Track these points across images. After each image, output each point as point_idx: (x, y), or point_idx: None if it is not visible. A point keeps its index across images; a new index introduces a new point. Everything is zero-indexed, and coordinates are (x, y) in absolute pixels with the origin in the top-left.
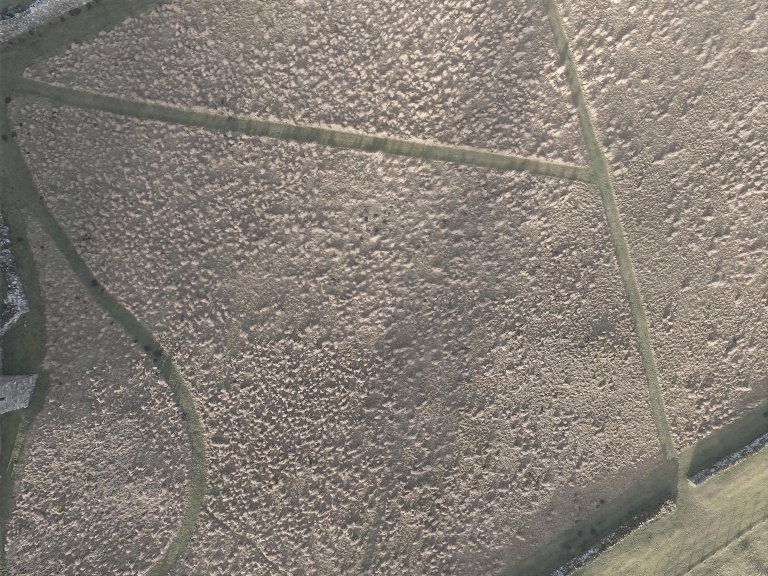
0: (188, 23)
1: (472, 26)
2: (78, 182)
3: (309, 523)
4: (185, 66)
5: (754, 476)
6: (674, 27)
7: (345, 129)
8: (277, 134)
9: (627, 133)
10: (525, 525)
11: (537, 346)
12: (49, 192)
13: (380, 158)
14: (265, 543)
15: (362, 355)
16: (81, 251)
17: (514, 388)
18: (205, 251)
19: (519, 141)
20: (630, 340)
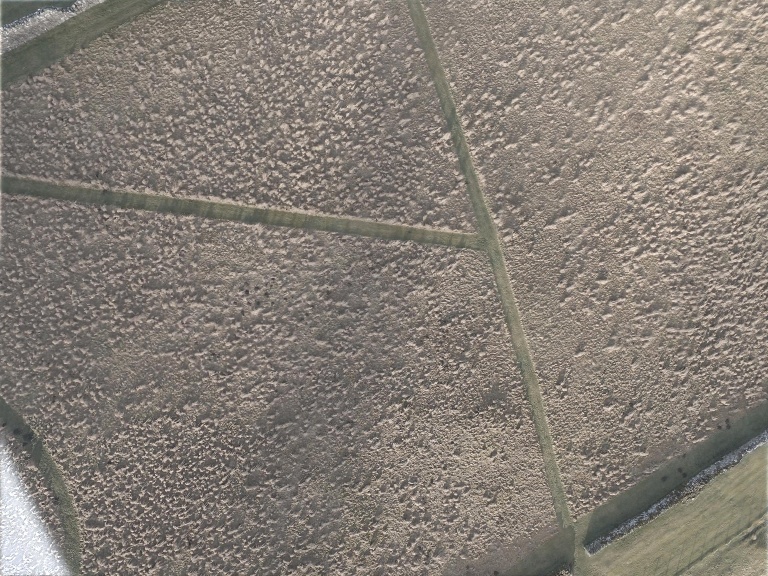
0: (61, 95)
1: (355, 93)
2: None
3: None
4: (58, 139)
5: (653, 542)
6: (565, 89)
7: (224, 201)
8: (154, 207)
9: (517, 198)
10: None
11: (425, 418)
12: None
13: (260, 230)
14: None
15: (244, 431)
16: None
17: (402, 461)
18: (78, 329)
19: (404, 210)
20: (522, 408)
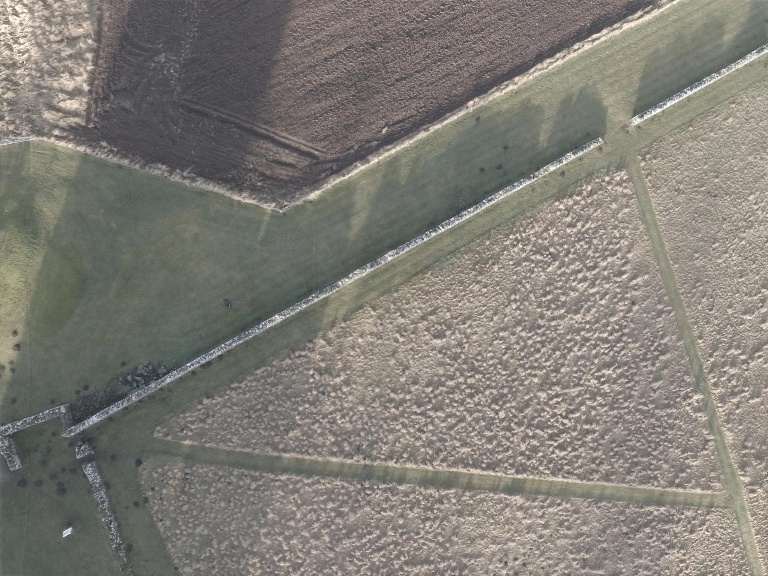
0: (322, 368)
1: (609, 357)
2: (214, 549)
3: None
4: (320, 414)
5: None
6: None
7: (484, 472)
8: (414, 480)
9: (761, 452)
10: None
11: None
12: (184, 562)
13: (520, 501)
14: None
15: None
16: None
17: None
18: None
19: (658, 474)
20: None
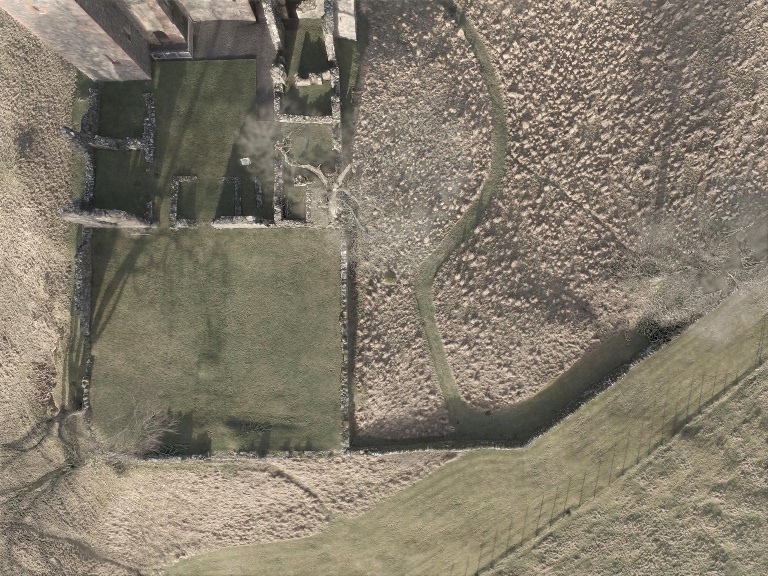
0: None
1: None
2: None
3: (605, 165)
4: None
5: None
6: None
7: None
8: None
9: None
10: None
11: None
12: None
13: None
14: (568, 184)
15: (632, 13)
16: None
17: None
18: None
19: None
20: None
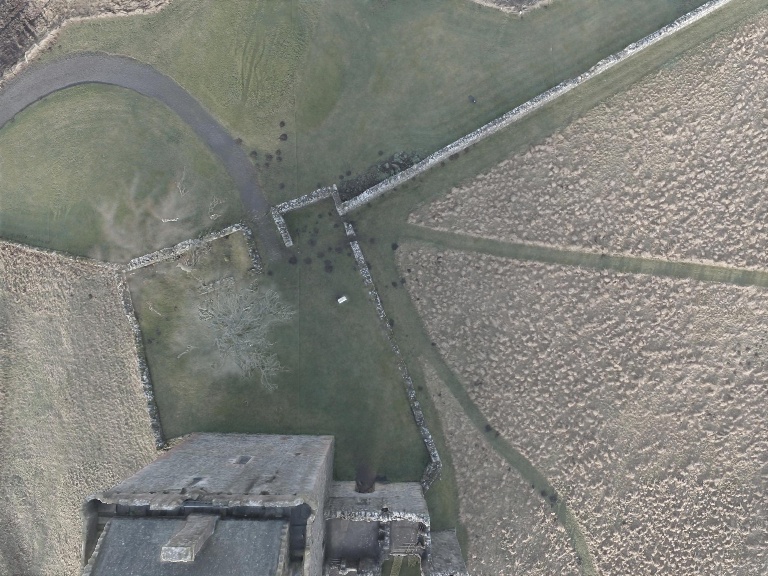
0: (560, 163)
1: None
2: (468, 327)
3: None
4: (559, 205)
5: None
6: None
7: (716, 263)
8: (649, 270)
9: None
10: None
11: None
12: (441, 338)
13: (752, 292)
14: None
15: (741, 491)
16: (475, 397)
17: None
18: (589, 392)
19: None
20: None
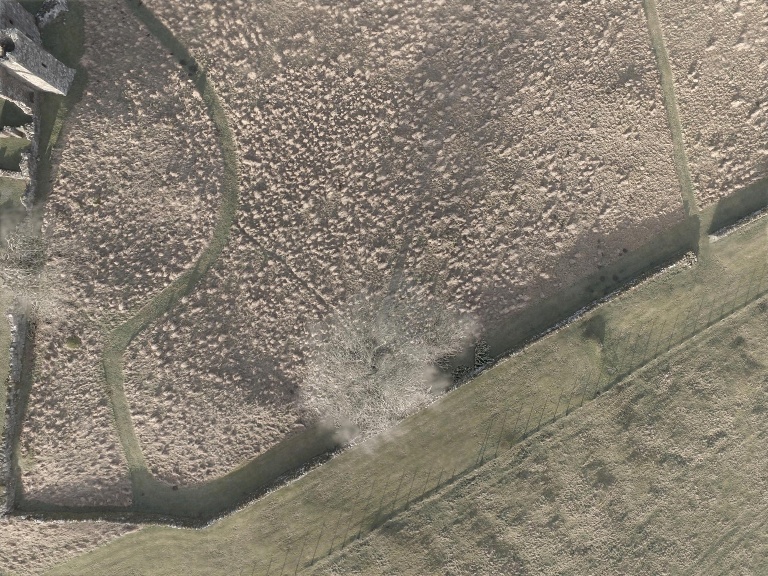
0: None
1: None
2: None
3: (338, 244)
4: None
5: None
6: None
7: None
8: None
9: None
10: (549, 265)
11: (564, 90)
12: None
13: None
14: (294, 260)
15: (393, 87)
16: None
17: (541, 130)
18: None
19: None
20: (656, 92)
